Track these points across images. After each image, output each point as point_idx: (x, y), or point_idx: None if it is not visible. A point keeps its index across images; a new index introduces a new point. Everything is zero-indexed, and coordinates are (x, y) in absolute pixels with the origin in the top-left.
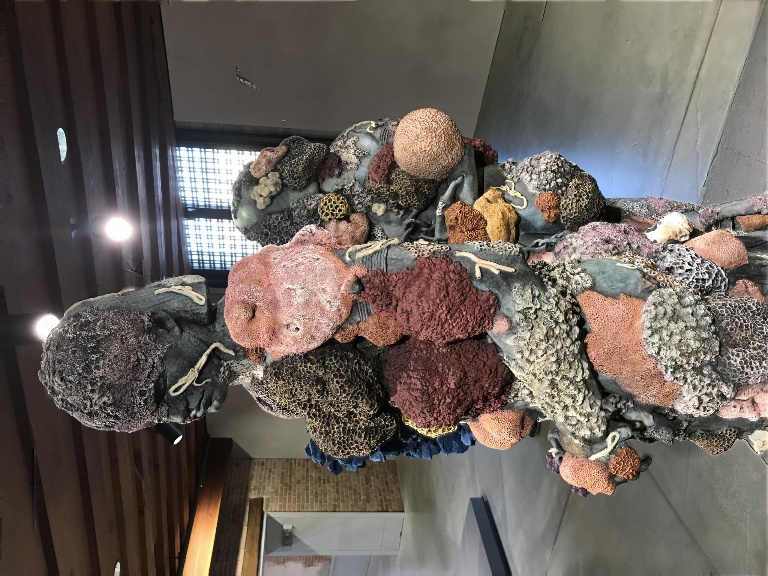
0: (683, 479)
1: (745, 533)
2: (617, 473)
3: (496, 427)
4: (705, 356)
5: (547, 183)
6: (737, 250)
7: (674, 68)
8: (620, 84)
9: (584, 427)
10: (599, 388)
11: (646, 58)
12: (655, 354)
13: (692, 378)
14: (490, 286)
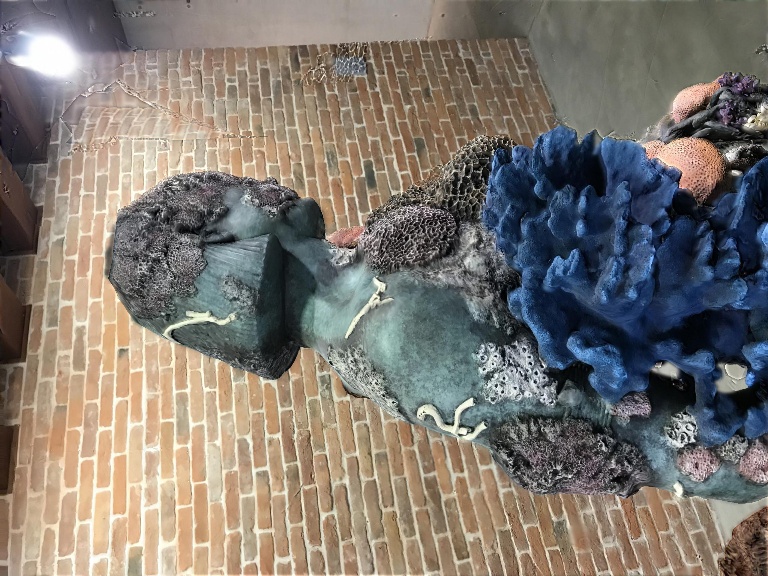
0: None
1: None
2: None
3: None
4: None
5: None
6: None
7: None
8: None
9: None
10: None
11: None
12: None
13: None
14: None
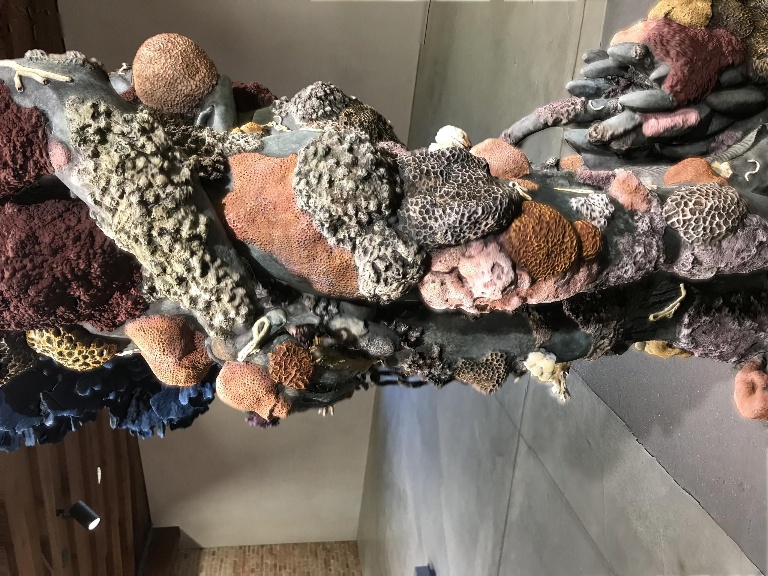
0: (600, 507)
1: (661, 558)
2: (281, 380)
3: (145, 342)
4: (368, 203)
5: (314, 112)
6: (512, 157)
7: (553, 78)
8: (512, 106)
9: (217, 311)
10: (262, 273)
11: (529, 74)
12: (305, 206)
13: (361, 238)
14: (36, 101)
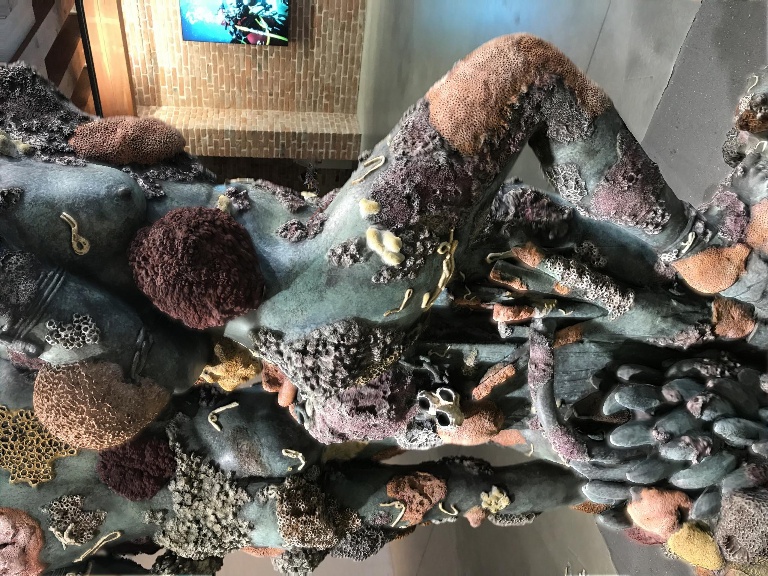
0: None
1: None
2: None
3: None
4: None
5: None
6: None
7: None
8: None
9: None
10: None
11: None
12: None
13: None
14: None
